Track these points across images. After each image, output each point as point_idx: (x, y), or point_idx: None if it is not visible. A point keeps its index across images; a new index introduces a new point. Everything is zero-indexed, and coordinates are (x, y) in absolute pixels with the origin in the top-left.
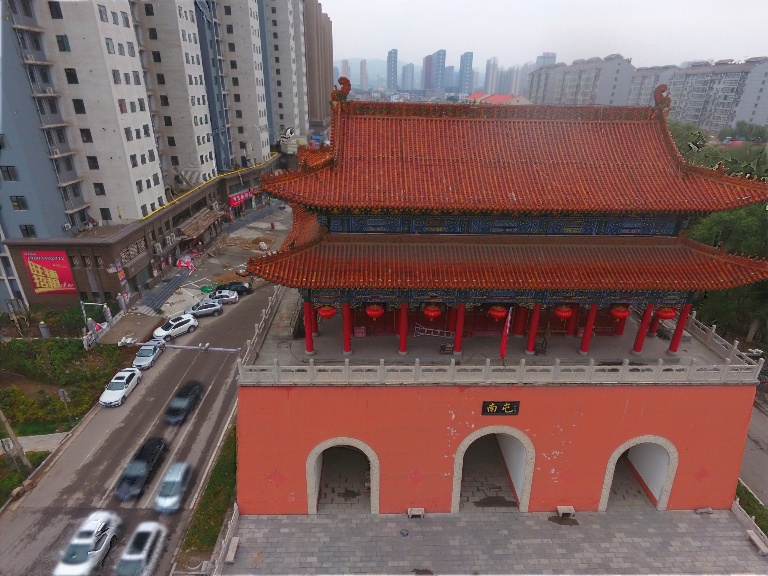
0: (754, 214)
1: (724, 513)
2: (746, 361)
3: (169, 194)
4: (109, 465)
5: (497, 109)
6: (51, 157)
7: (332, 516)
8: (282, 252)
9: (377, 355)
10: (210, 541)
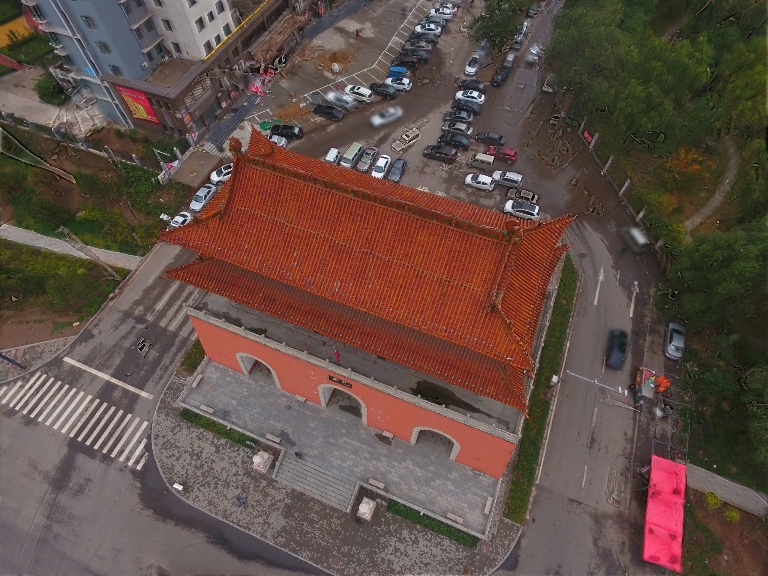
0: (767, 258)
1: (491, 479)
2: (668, 374)
3: (237, 17)
4: (160, 292)
5: (361, 193)
6: (118, 2)
7: (256, 380)
8: (193, 263)
9: (276, 318)
10: (193, 367)
